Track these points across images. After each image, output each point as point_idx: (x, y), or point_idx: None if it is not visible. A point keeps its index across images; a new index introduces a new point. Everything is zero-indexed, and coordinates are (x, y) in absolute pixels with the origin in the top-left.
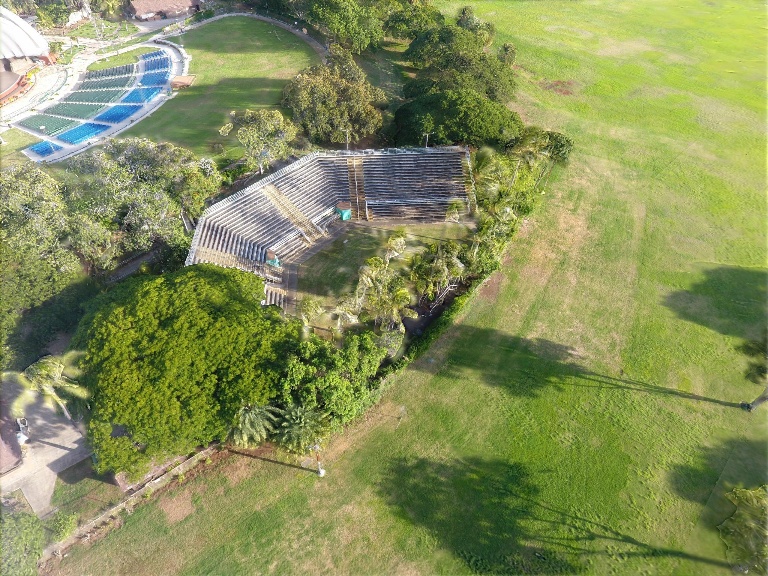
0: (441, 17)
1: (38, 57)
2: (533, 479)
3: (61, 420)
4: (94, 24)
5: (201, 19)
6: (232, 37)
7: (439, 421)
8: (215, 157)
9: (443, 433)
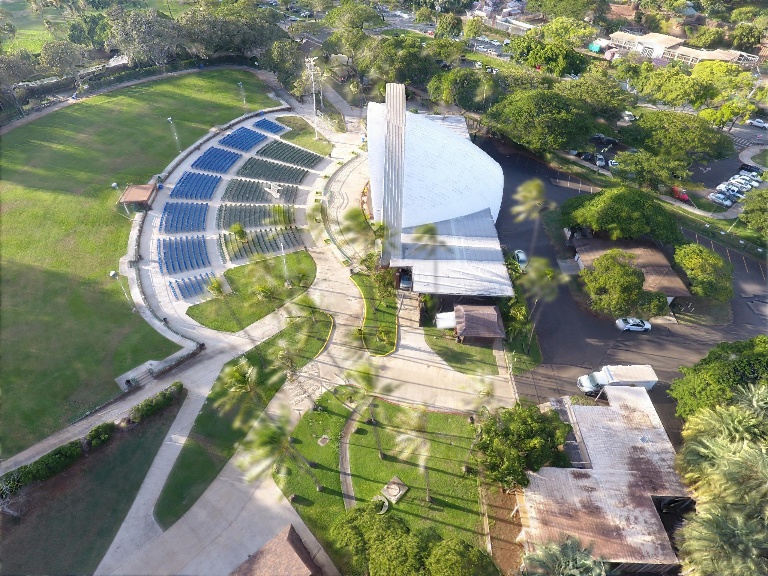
0: None
1: None
2: None
3: None
4: None
5: None
6: (6, 332)
7: None
8: (115, 98)
9: None
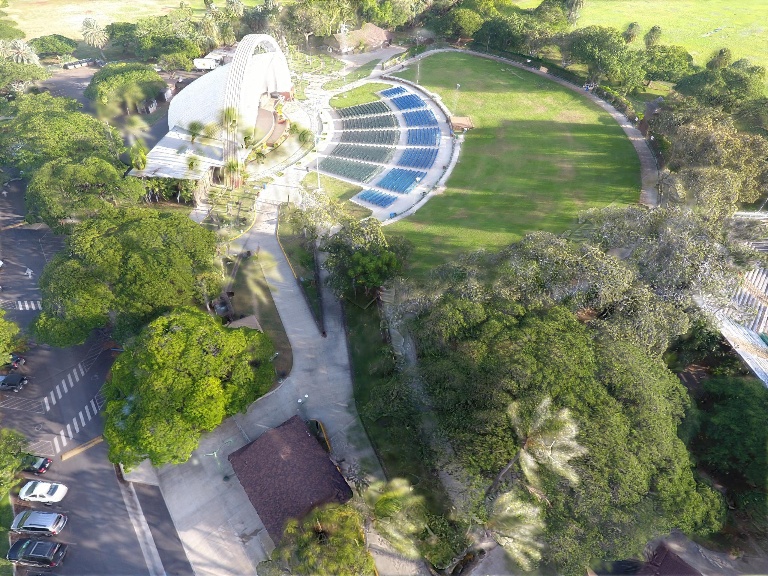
0: (691, 58)
1: (280, 92)
2: None
3: (718, 571)
4: (297, 57)
5: (414, 54)
6: (465, 74)
7: None
8: None
9: None
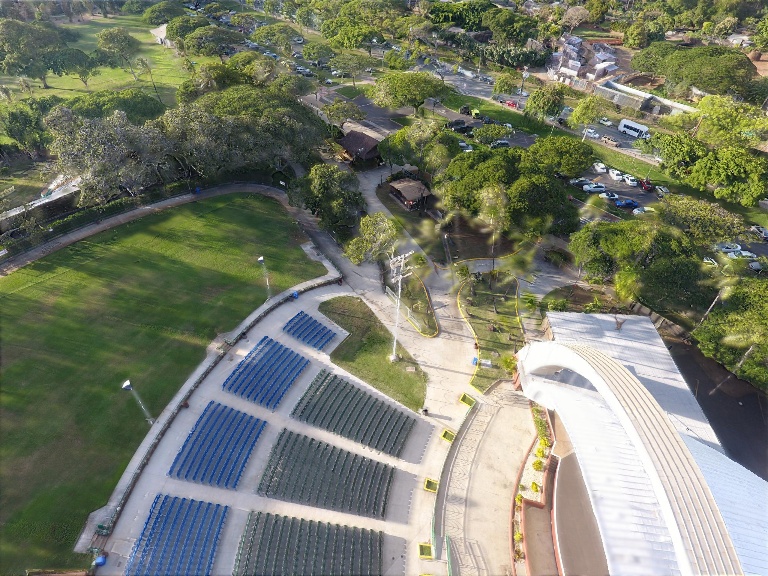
0: None
1: None
2: None
3: None
4: None
5: None
6: None
7: (5, 142)
8: (50, 275)
9: (7, 139)
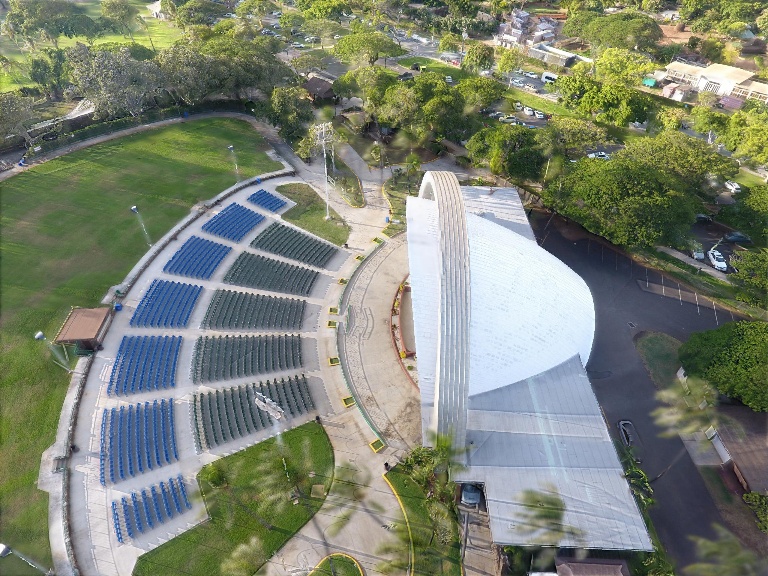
0: None
1: None
2: (6, 80)
3: None
4: None
5: None
6: None
7: None
8: (74, 164)
9: None
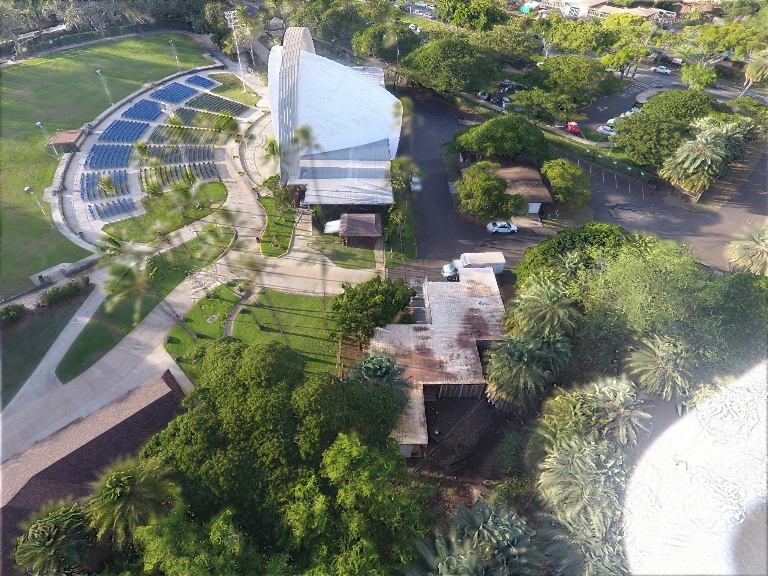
0: None
1: None
2: None
3: None
4: None
5: None
6: None
7: None
8: (53, 60)
9: None
